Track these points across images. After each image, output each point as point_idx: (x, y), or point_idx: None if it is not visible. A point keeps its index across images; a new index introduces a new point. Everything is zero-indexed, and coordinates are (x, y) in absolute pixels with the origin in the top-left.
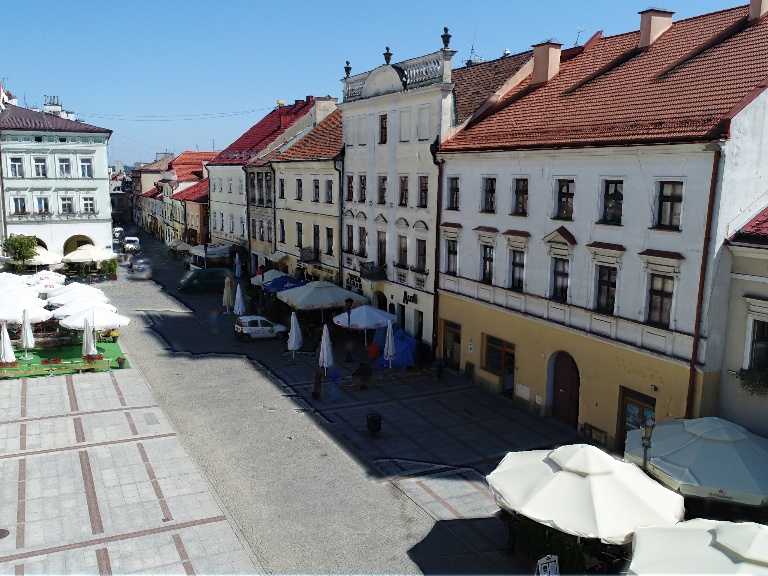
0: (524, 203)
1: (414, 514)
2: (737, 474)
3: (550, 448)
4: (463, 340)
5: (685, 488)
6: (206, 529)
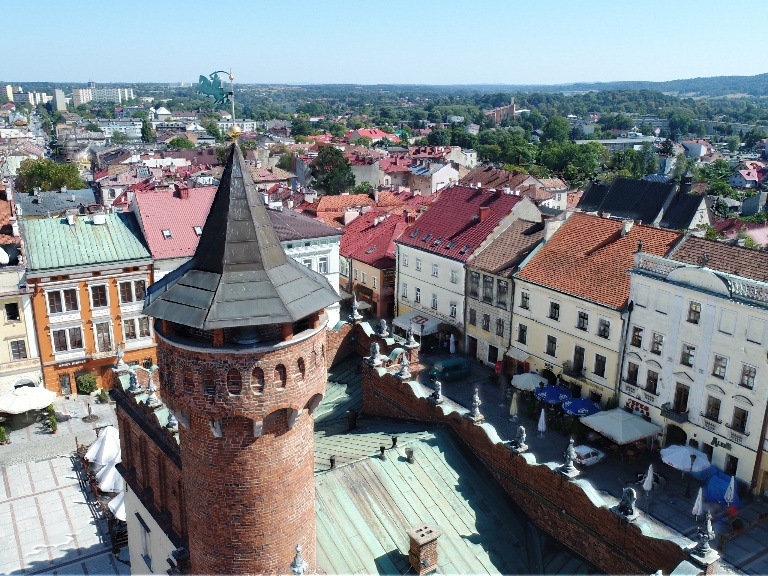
0: None
1: None
2: None
3: None
4: None
5: None
6: None
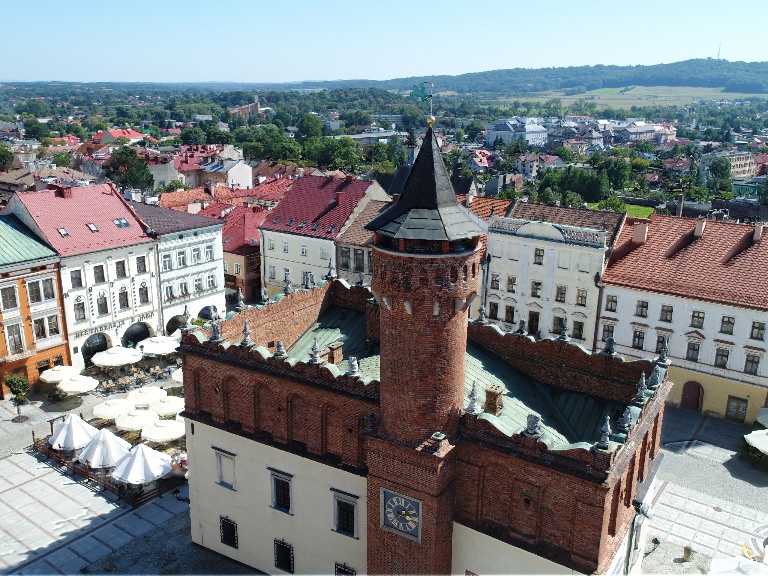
0: (668, 316)
1: None
2: None
3: (704, 424)
4: None
5: None
6: (671, 487)
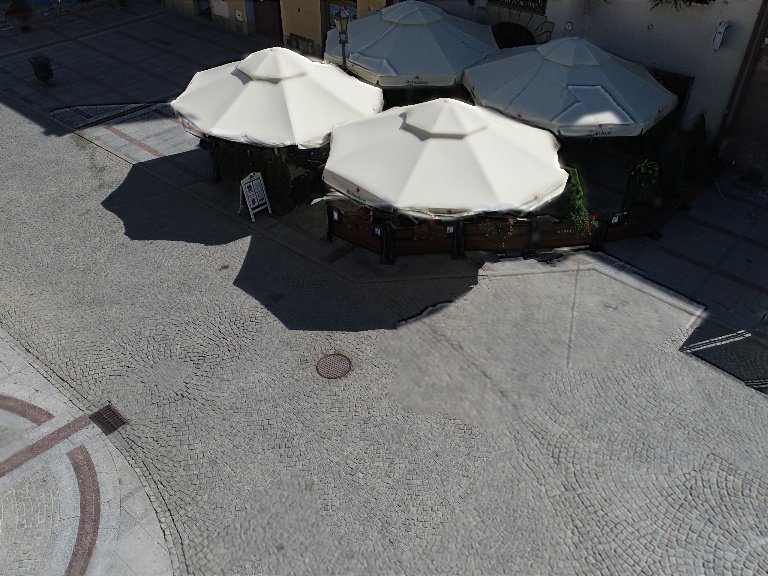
0: None
1: (106, 162)
2: (432, 57)
3: None
4: None
5: (383, 80)
6: None
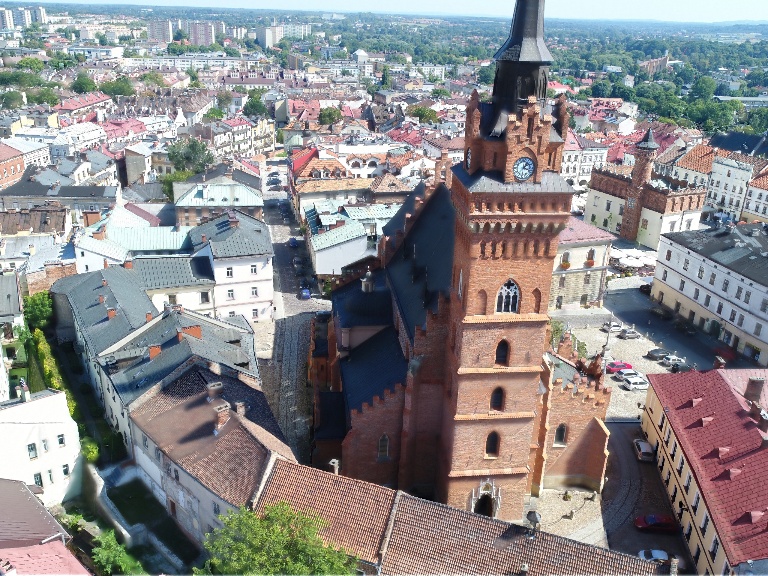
0: None
1: None
2: None
3: None
4: (748, 221)
5: None
6: None
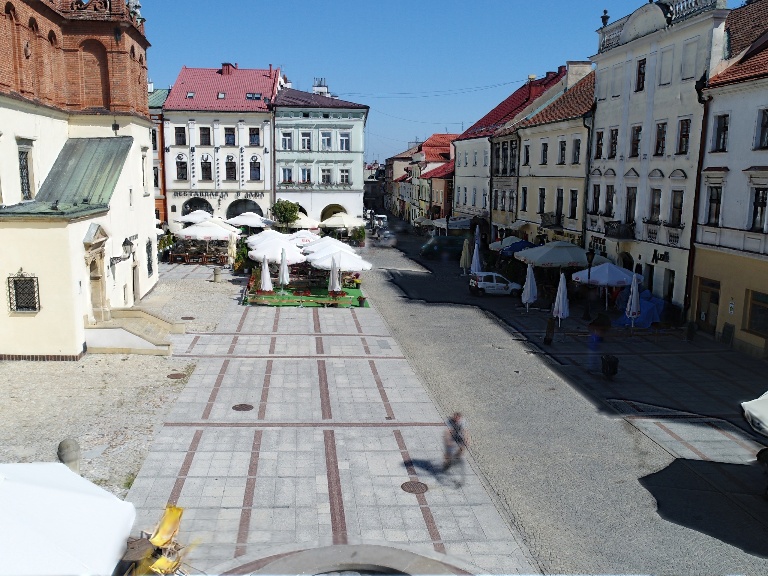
0: None
1: (649, 449)
2: None
3: None
4: (722, 299)
5: None
6: (426, 430)
